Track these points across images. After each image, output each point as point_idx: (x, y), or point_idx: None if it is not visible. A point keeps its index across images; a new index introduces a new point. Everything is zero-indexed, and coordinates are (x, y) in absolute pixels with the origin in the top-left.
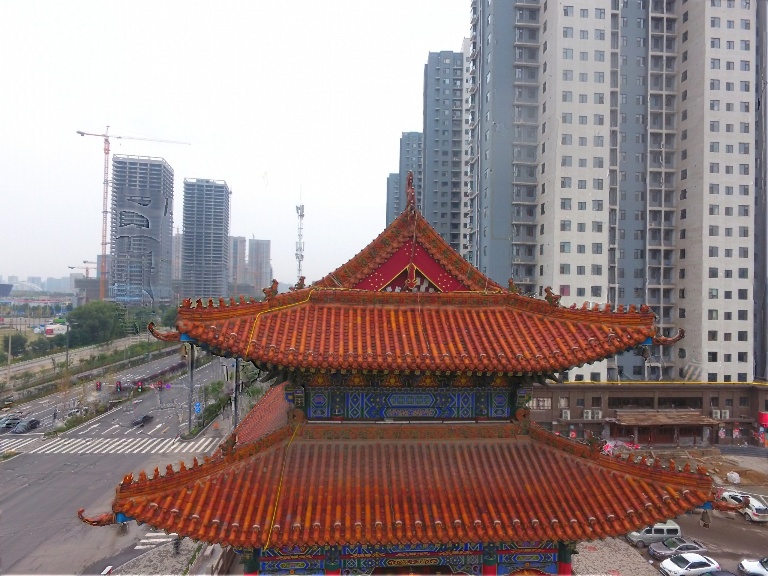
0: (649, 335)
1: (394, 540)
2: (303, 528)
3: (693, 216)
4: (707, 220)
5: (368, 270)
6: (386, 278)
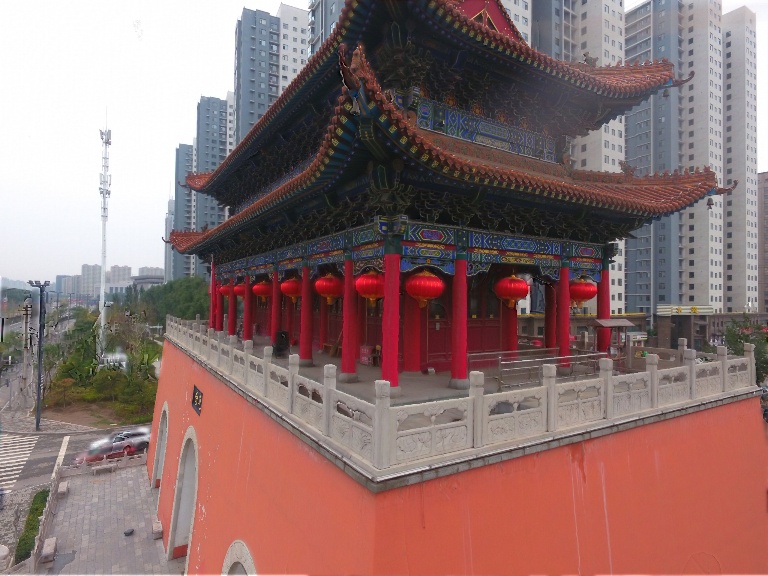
0: (671, 77)
1: (558, 187)
2: None
3: None
4: None
5: (455, 1)
6: None
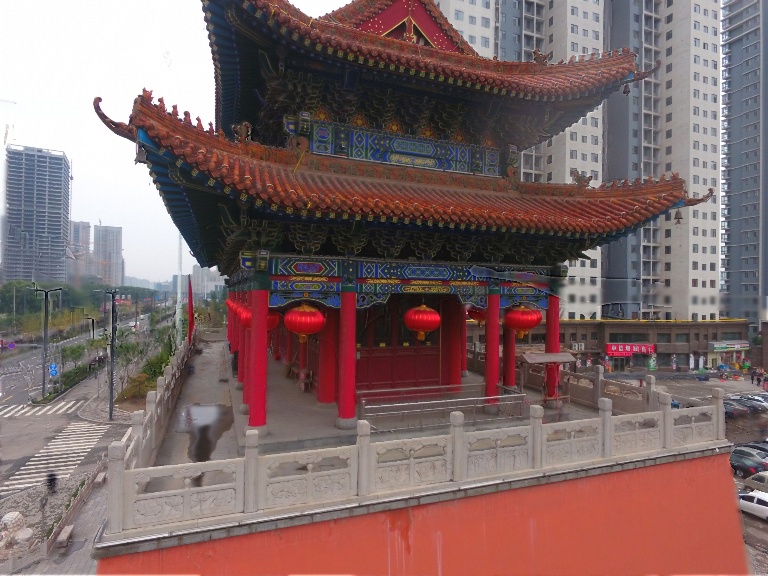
0: (632, 70)
1: (436, 214)
2: (343, 200)
3: (557, 177)
4: (568, 181)
5: (368, 13)
6: (386, 26)
